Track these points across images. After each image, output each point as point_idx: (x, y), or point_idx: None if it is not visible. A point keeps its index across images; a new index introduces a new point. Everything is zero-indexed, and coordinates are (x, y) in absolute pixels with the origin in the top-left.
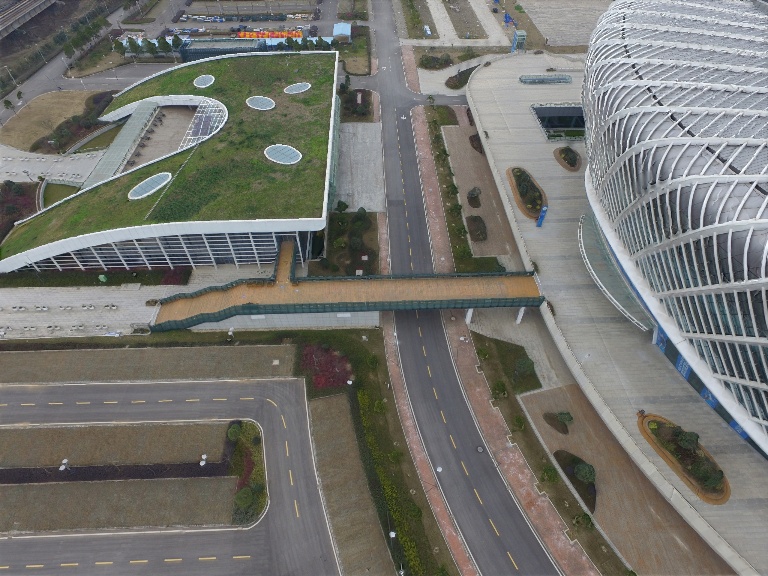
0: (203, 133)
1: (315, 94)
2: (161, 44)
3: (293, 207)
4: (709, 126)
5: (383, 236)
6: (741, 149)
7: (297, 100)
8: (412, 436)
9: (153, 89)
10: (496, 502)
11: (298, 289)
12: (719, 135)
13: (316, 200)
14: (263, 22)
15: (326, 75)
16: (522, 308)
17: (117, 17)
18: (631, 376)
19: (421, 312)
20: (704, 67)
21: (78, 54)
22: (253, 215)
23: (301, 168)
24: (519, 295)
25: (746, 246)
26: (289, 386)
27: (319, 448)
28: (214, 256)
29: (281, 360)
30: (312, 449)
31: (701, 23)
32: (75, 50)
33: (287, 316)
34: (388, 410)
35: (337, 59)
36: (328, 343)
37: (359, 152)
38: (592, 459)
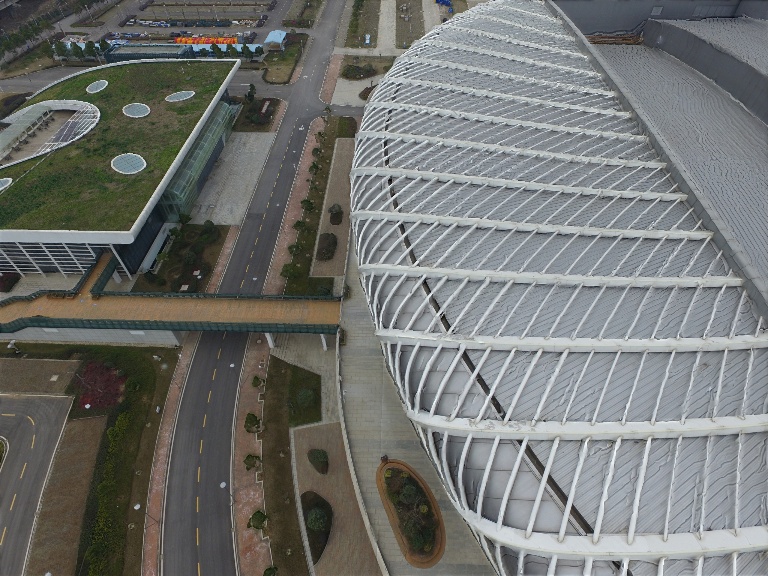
0: (64, 139)
1: (194, 103)
2: (86, 48)
3: (109, 219)
4: (405, 156)
5: (226, 251)
6: (412, 183)
7: (173, 108)
8: (159, 465)
9: (54, 93)
10: (213, 544)
11: (97, 303)
12: (409, 166)
13: (135, 212)
14: (207, 28)
15: (215, 83)
16: (321, 335)
17: (70, 20)
18: (394, 416)
19: (230, 333)
20: (453, 90)
21: (11, 56)
22: (66, 225)
23: (138, 178)
24: (318, 321)
25: (369, 293)
26: (56, 404)
27: (55, 472)
28: (37, 264)
29: (60, 376)
30: (48, 473)
31: (495, 41)
32: (7, 52)
33: (80, 331)
34: (146, 436)
35: (234, 67)
36: (114, 361)
37: (241, 162)
38: (340, 503)
